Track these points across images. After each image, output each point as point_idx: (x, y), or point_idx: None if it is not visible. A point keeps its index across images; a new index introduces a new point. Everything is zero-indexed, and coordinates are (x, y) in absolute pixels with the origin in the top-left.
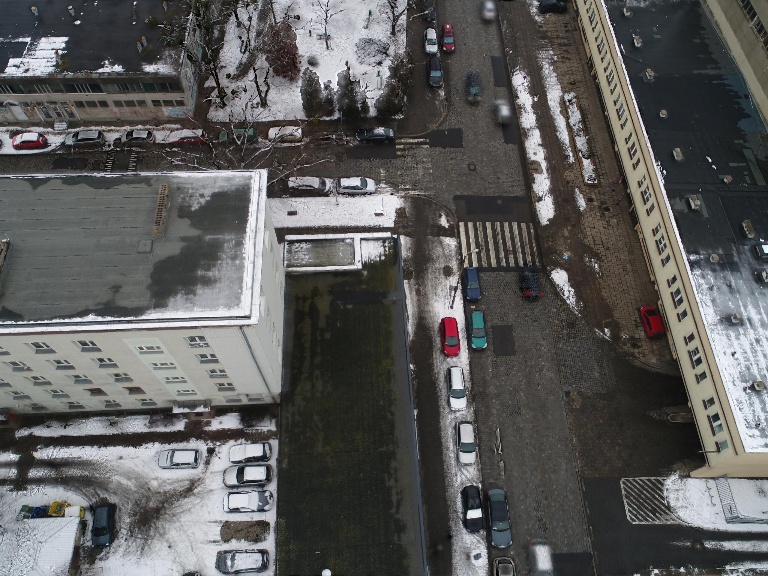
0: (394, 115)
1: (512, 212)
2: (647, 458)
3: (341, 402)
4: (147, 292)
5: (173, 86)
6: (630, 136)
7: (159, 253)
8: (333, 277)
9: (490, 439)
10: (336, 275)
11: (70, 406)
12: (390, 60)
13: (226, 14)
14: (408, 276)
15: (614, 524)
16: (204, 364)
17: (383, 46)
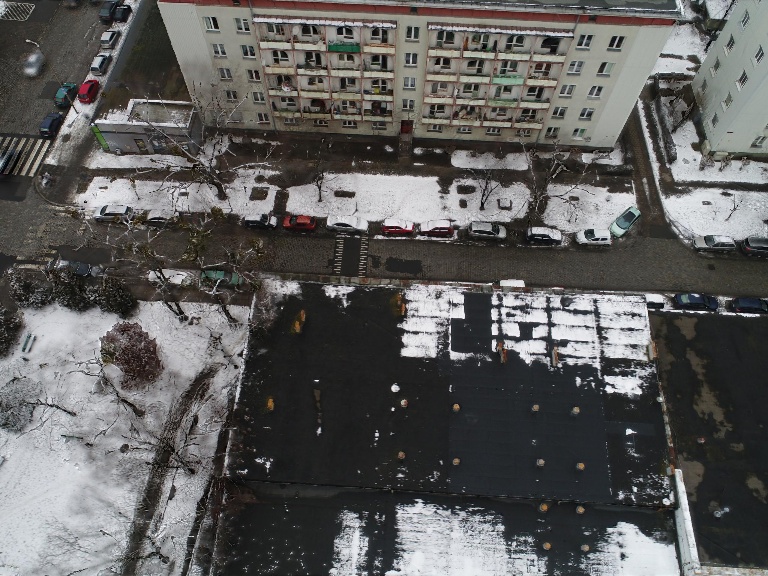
0: None
1: None
2: (1, 27)
3: None
4: None
5: None
6: None
7: None
8: None
9: (94, 43)
10: None
11: None
12: None
13: None
14: None
15: (45, 5)
16: None
17: None
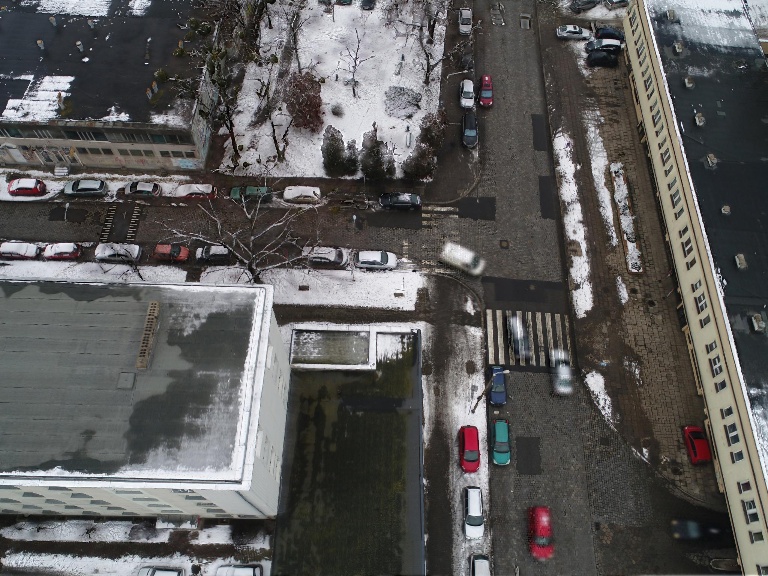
0: (422, 178)
1: (546, 300)
2: None
3: (343, 531)
4: (124, 441)
5: (183, 138)
6: (685, 230)
7: (142, 390)
8: (344, 376)
9: (507, 575)
10: (347, 374)
11: (44, 510)
12: (422, 120)
13: (248, 51)
14: (427, 371)
15: None
16: (190, 500)
17: (415, 97)
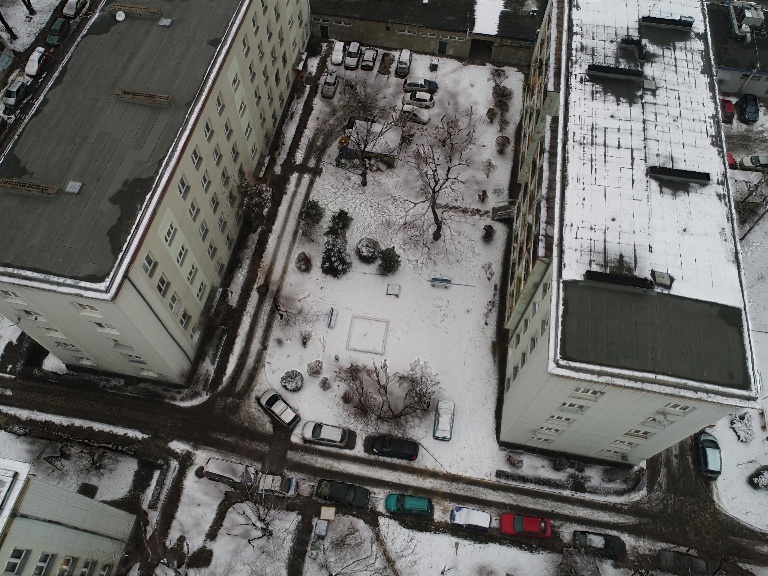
0: None
1: None
2: None
3: None
4: None
5: None
6: None
7: None
8: None
9: None
10: None
11: None
12: None
13: None
14: None
15: None
16: None
17: None
